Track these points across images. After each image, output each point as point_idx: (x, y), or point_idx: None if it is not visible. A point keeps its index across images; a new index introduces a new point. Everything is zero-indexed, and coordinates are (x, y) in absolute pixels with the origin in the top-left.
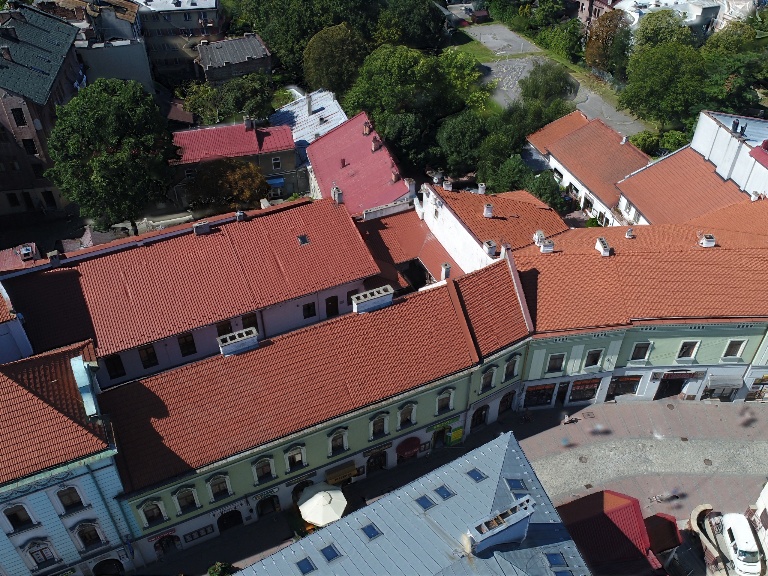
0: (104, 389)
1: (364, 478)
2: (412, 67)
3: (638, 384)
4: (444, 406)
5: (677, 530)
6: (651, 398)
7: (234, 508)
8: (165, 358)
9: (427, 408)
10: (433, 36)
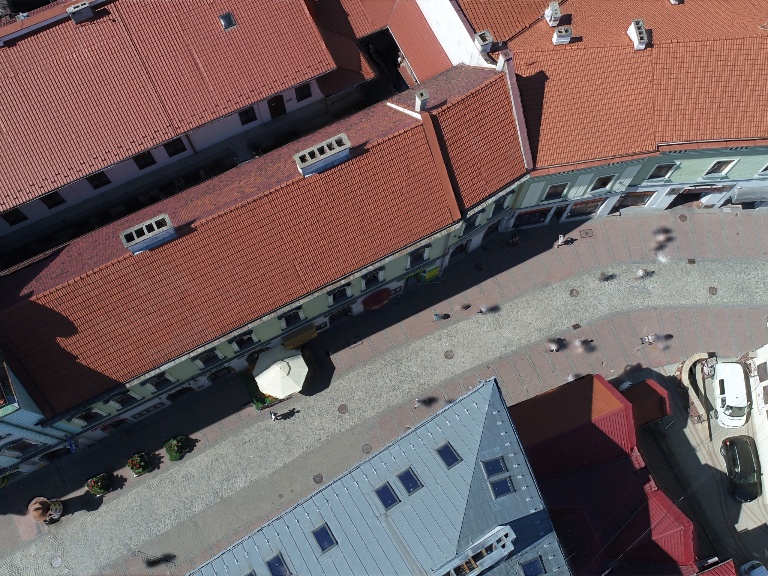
0: (6, 237)
1: (327, 328)
2: None
3: (650, 197)
4: (417, 256)
5: (667, 404)
6: (662, 208)
7: (182, 387)
8: (72, 195)
9: (397, 266)
10: None
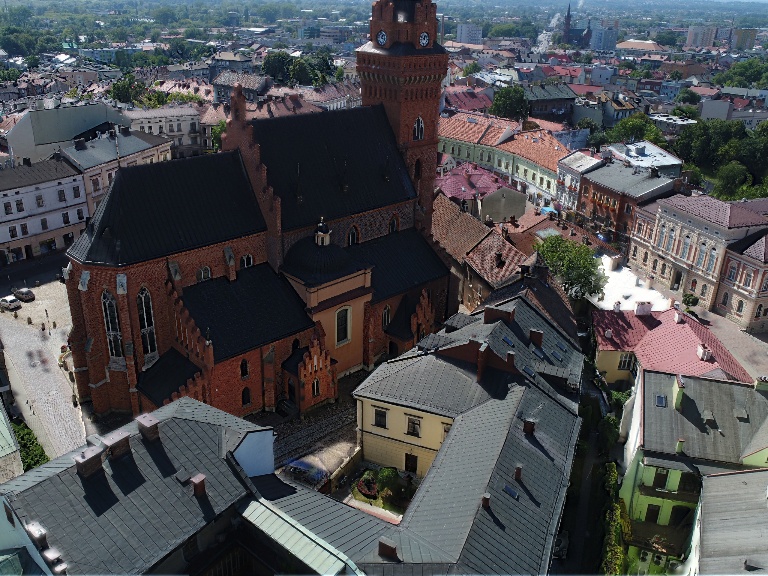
0: None
1: None
2: None
3: None
4: None
5: None
6: None
7: None
8: None
9: None
10: (757, 161)
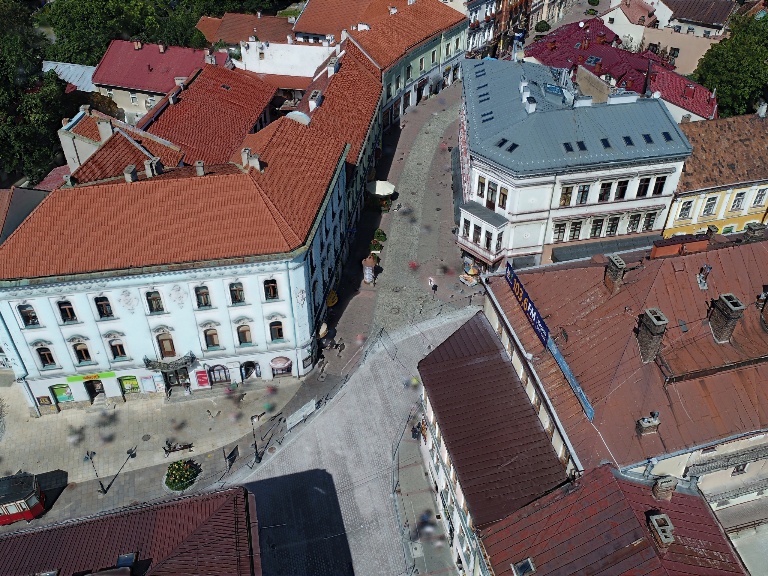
0: None
1: None
2: (105, 6)
3: (410, 98)
4: None
5: None
6: None
7: None
8: None
9: None
10: None
